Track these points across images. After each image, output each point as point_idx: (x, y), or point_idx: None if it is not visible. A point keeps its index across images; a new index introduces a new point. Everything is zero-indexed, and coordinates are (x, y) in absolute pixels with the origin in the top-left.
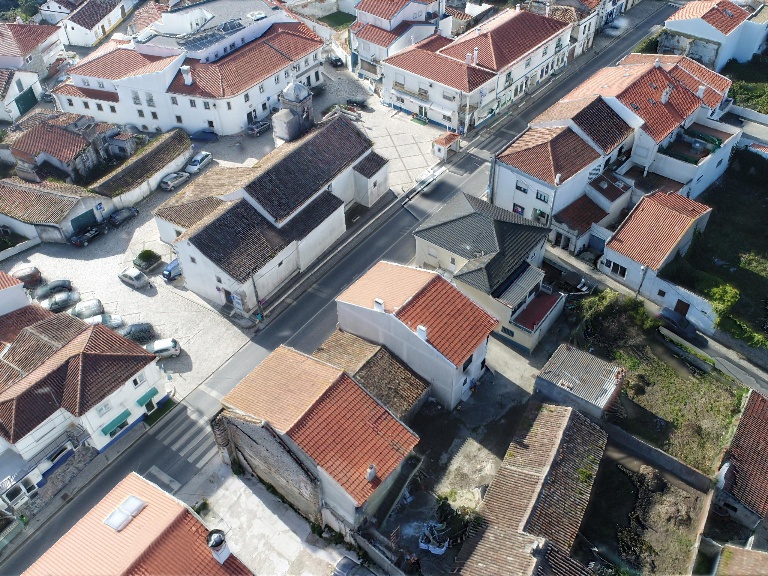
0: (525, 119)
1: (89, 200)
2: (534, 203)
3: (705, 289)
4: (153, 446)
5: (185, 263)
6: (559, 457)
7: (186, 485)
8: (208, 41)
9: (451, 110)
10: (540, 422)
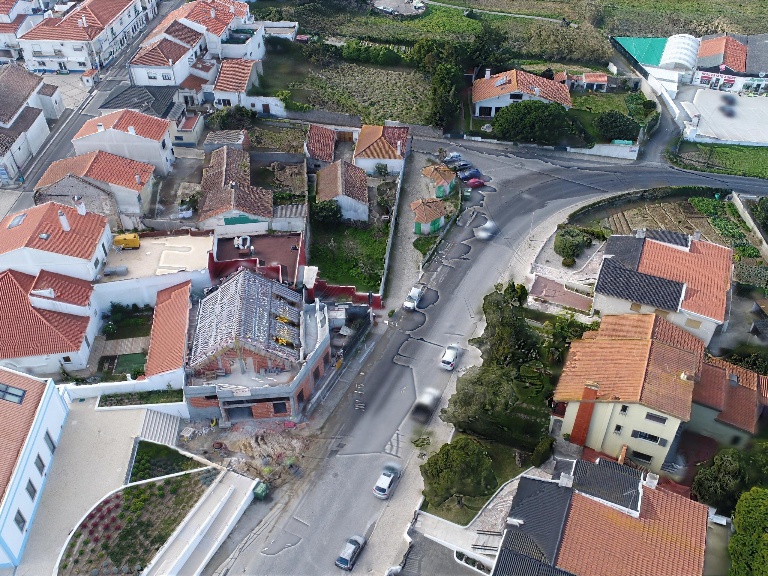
0: None
1: None
2: (163, 83)
3: (273, 95)
4: None
5: None
6: (229, 162)
7: None
8: None
9: (83, 57)
10: (214, 157)
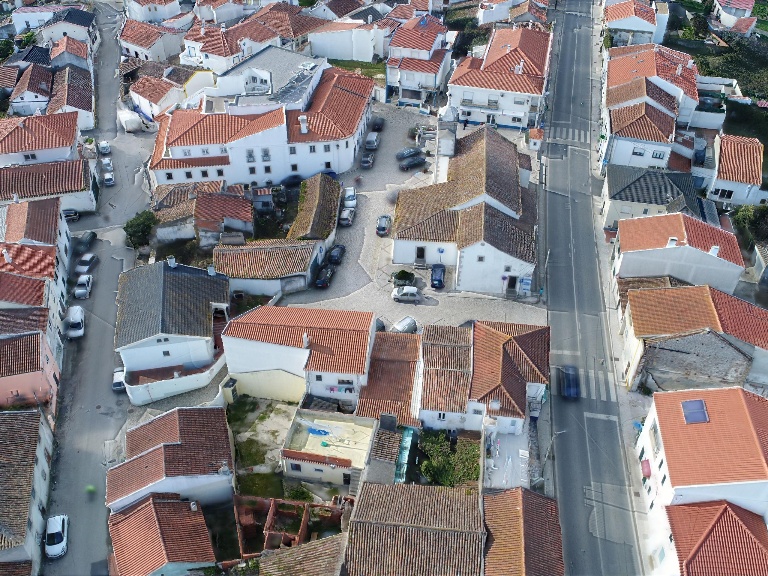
0: (561, 111)
1: (317, 244)
2: (650, 162)
3: None
4: (568, 401)
5: (468, 265)
6: None
7: (621, 415)
8: (294, 93)
9: (522, 112)
10: None
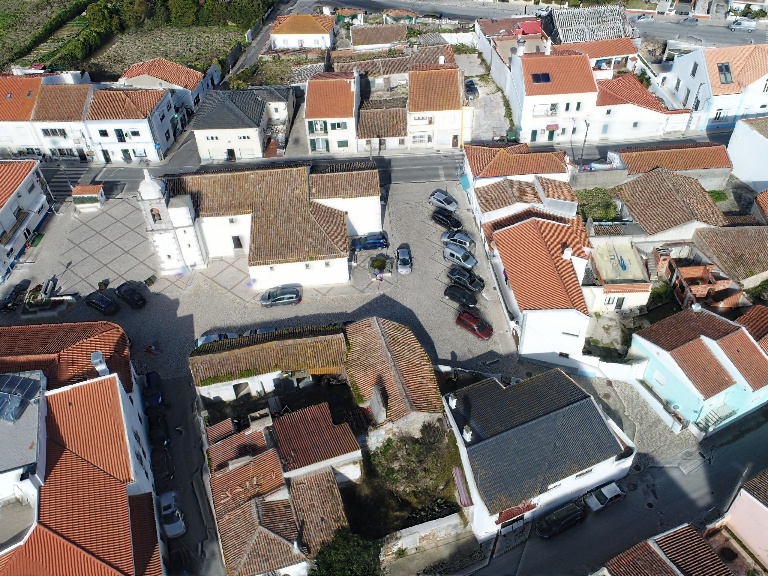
0: None
1: None
2: None
3: (200, 70)
4: None
5: None
6: None
7: None
8: None
9: (40, 195)
10: None
